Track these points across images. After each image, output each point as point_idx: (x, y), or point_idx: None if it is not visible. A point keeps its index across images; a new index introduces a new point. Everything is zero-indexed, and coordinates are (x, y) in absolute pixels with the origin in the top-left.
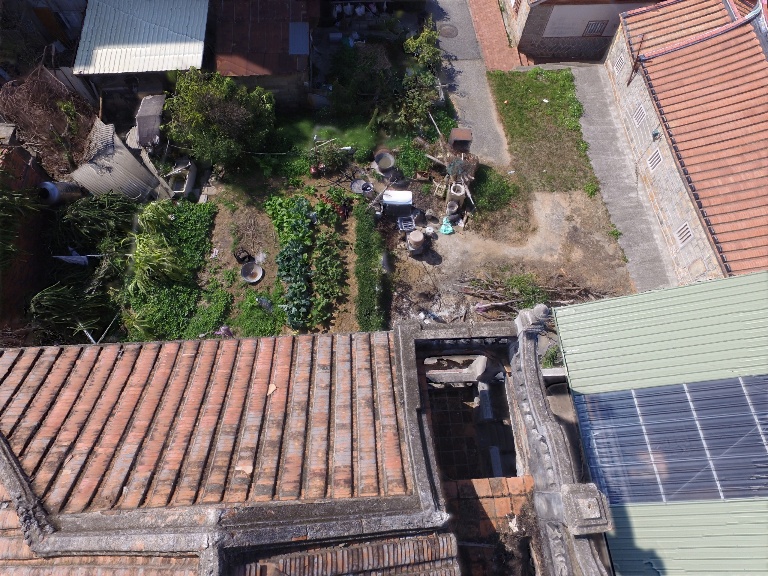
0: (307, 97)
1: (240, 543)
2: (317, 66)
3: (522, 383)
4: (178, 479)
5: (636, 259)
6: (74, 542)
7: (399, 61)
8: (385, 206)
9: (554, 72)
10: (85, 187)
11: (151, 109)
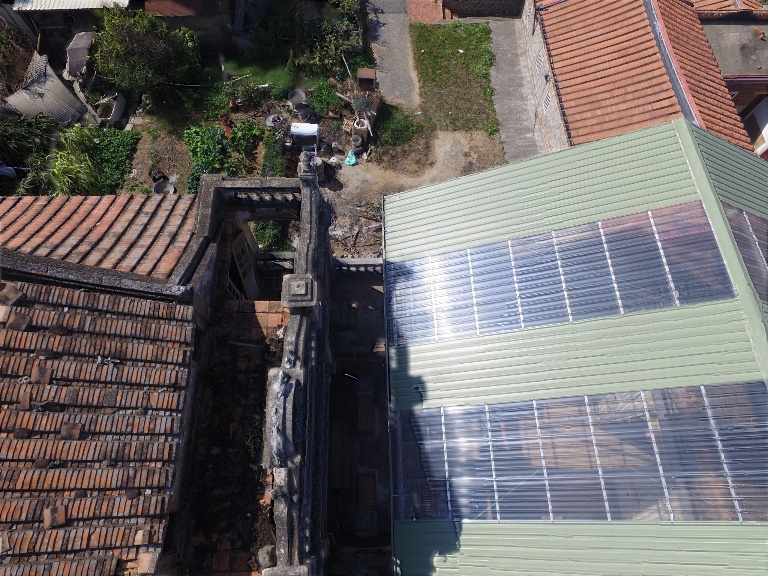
0: (231, 40)
1: None
2: (250, 15)
3: None
4: None
5: None
6: None
7: (327, 12)
8: (292, 137)
9: (473, 25)
10: (18, 110)
11: (81, 43)
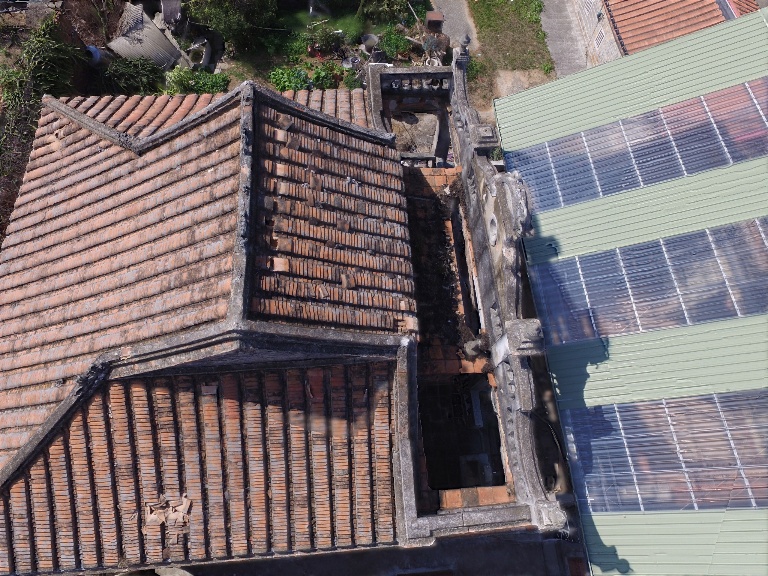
0: None
1: (265, 93)
2: None
3: (457, 111)
4: None
5: None
6: (161, 133)
7: None
8: None
9: None
10: (120, 55)
11: None
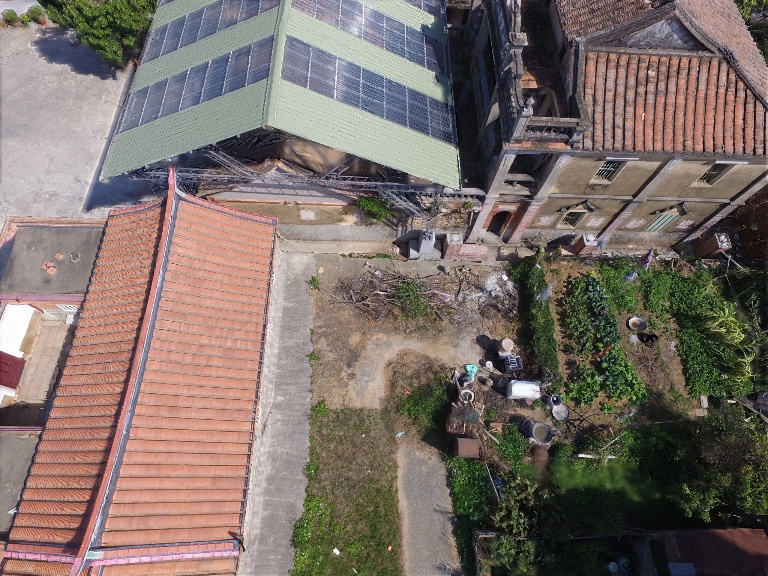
0: None
1: (665, 5)
2: None
3: None
4: (678, 71)
5: (303, 331)
6: None
7: None
8: None
9: None
10: None
11: None
